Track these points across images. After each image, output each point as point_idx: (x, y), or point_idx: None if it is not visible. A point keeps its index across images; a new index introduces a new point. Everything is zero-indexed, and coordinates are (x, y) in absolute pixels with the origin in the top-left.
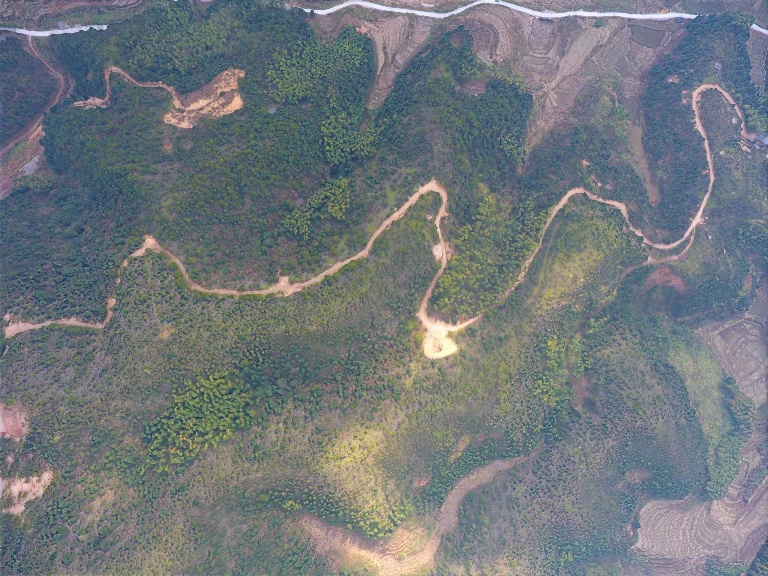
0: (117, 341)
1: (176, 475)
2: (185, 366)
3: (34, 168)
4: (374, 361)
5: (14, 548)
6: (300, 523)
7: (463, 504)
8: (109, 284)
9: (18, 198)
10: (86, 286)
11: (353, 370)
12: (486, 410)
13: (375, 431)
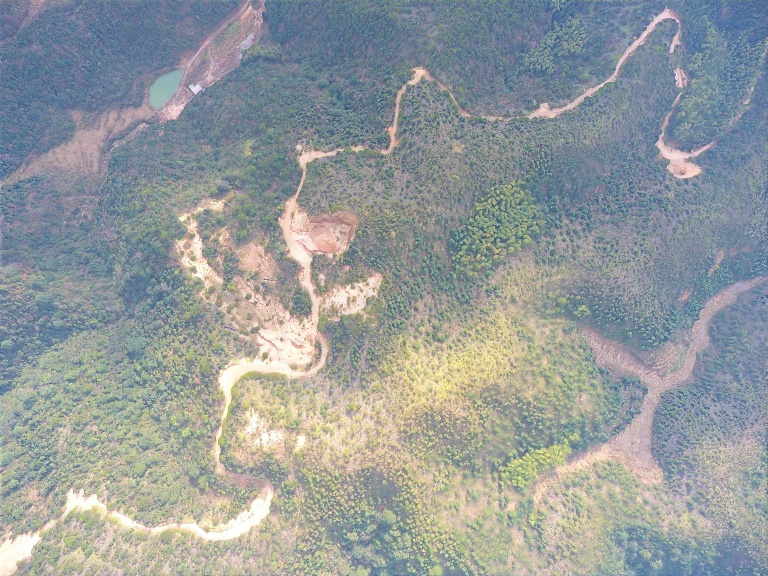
0: (413, 158)
1: (486, 278)
2: (486, 174)
3: (250, 45)
4: (627, 184)
5: (359, 342)
6: (581, 336)
7: (714, 323)
8: (385, 115)
9: (252, 65)
10: (359, 121)
11: (611, 191)
12: (745, 219)
13: (652, 237)
